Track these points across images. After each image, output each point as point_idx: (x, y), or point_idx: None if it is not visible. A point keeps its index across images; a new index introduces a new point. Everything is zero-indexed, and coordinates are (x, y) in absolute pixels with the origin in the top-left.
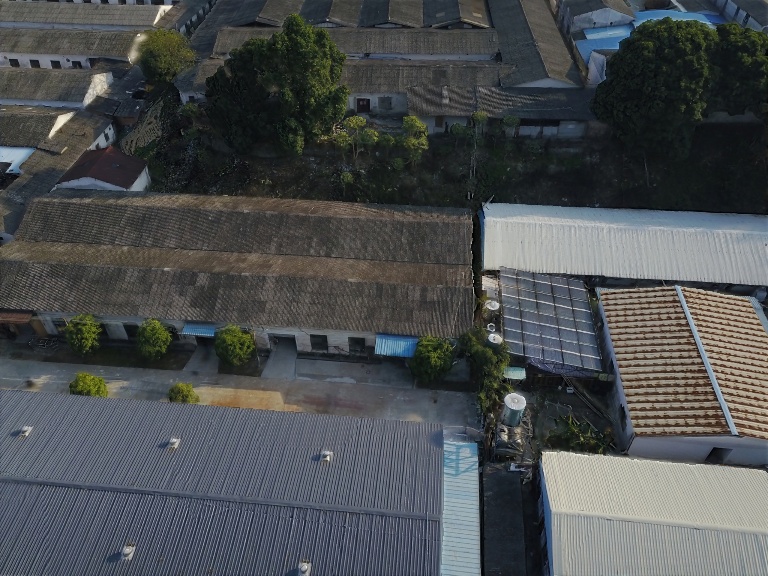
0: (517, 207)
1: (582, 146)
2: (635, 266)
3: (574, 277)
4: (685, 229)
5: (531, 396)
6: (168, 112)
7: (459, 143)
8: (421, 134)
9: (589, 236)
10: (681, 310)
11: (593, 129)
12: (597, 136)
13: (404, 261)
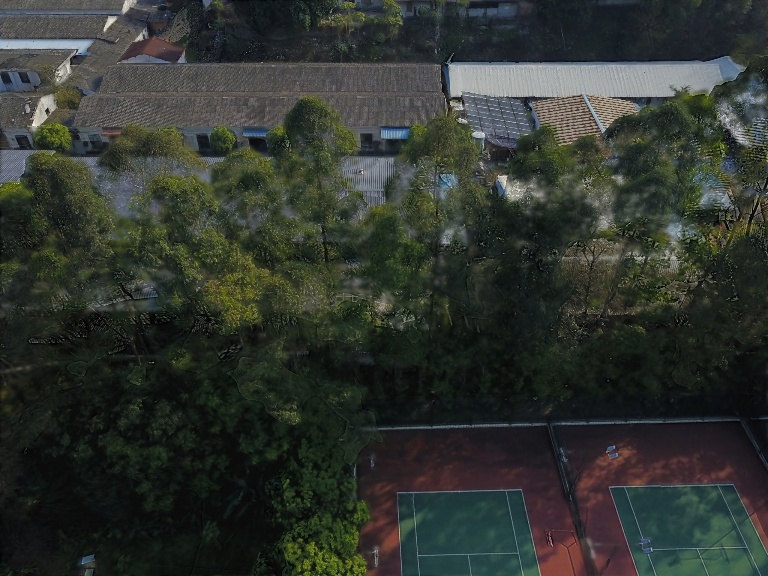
0: (471, 63)
1: (516, 23)
2: (556, 90)
3: (514, 98)
4: (589, 66)
5: (489, 165)
6: (194, 13)
7: (425, 23)
8: (397, 14)
9: (523, 73)
10: (585, 105)
11: (523, 9)
12: (526, 14)
13: (394, 91)
